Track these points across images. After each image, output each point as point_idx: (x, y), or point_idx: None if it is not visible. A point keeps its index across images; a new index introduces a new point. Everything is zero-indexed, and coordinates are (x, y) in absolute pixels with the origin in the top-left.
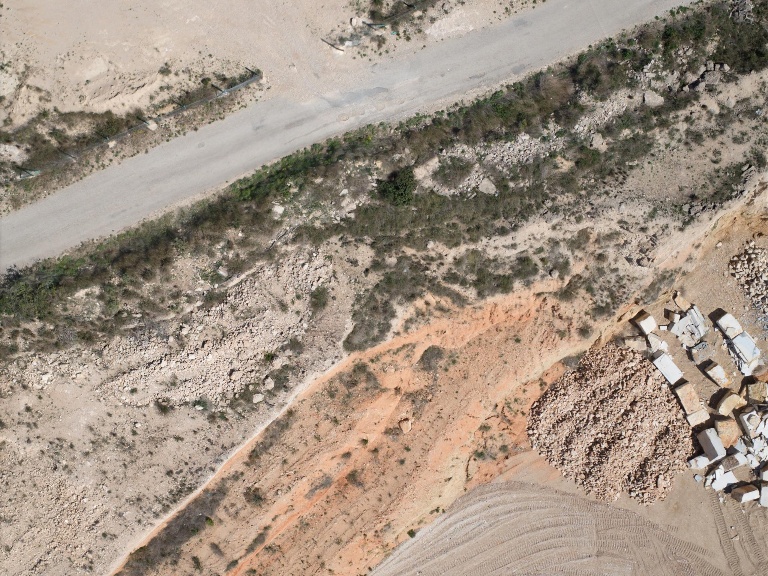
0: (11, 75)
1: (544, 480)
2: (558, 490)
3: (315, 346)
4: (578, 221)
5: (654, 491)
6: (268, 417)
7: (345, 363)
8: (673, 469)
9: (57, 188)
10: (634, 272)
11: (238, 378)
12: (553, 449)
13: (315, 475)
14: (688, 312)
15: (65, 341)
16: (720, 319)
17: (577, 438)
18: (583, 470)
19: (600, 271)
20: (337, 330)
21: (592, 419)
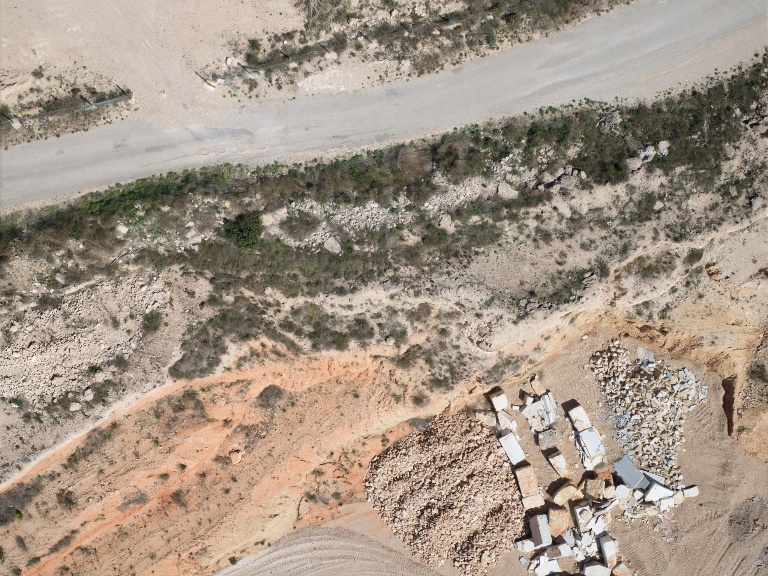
0: None
1: (374, 533)
2: (385, 545)
3: (140, 367)
4: (416, 295)
5: (477, 565)
6: (82, 427)
7: (174, 387)
8: (500, 547)
9: None
10: (476, 352)
11: (59, 384)
12: (386, 505)
13: (129, 490)
14: (542, 397)
15: None
16: (571, 410)
17: (410, 499)
18: (413, 531)
19: (442, 345)
20: (164, 356)
21: (428, 483)
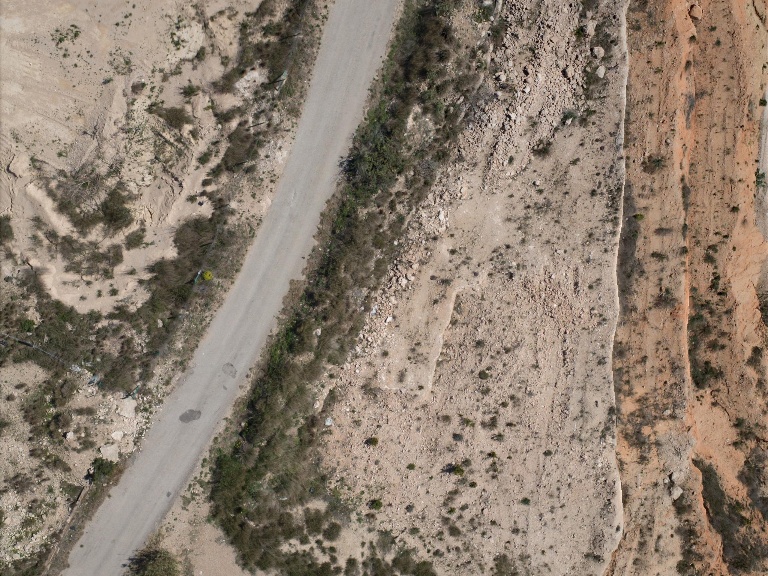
0: (190, 26)
1: None
2: None
3: None
4: None
5: None
6: (622, 78)
7: None
8: None
9: (310, 70)
10: None
11: (573, 72)
12: None
13: (681, 102)
14: None
15: (430, 174)
16: None
17: None
18: None
19: None
20: None
21: None
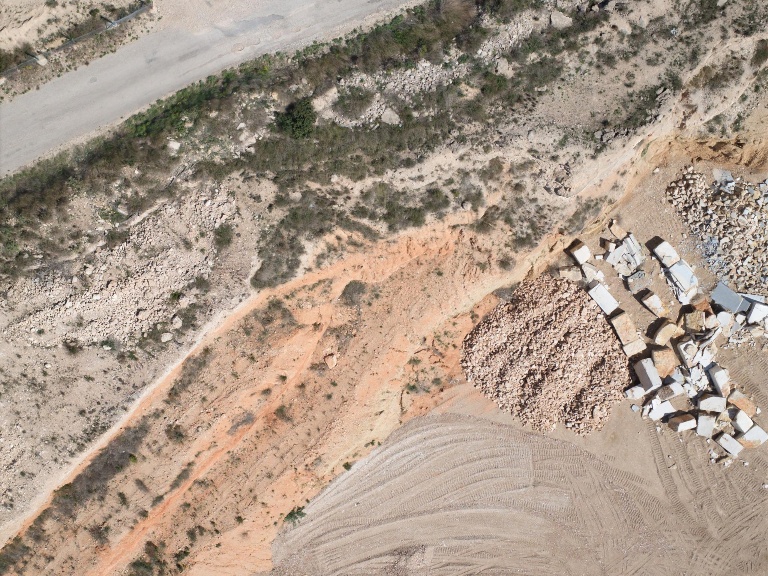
0: None
1: (480, 412)
2: (494, 422)
3: (222, 284)
4: (486, 151)
5: (590, 422)
6: (178, 356)
7: (258, 300)
8: (609, 399)
9: None
10: (555, 202)
11: (145, 317)
12: (488, 381)
13: (235, 412)
14: (624, 241)
15: None
16: (656, 247)
17: (510, 370)
18: (519, 402)
19: (518, 201)
20: (243, 267)
21: (525, 351)
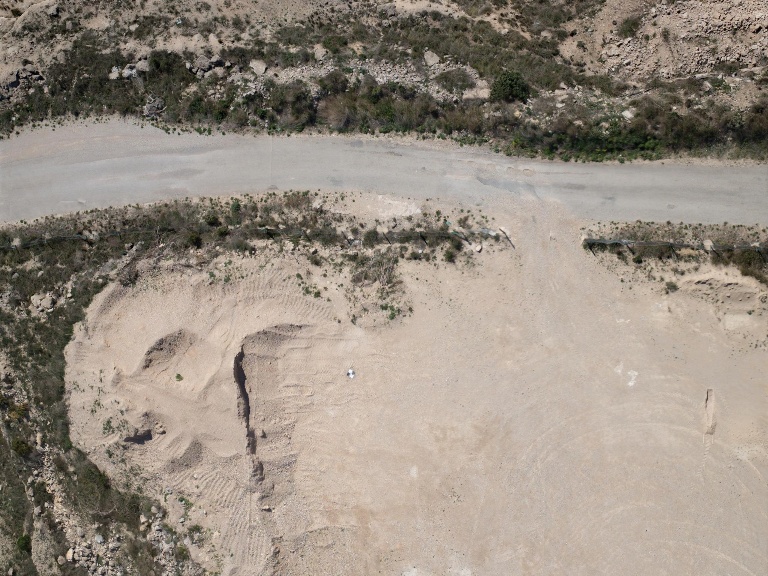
0: None
1: None
2: None
3: None
4: None
5: None
6: None
7: None
8: None
9: None
10: None
11: None
12: None
13: None
14: None
15: None
16: None
17: None
18: None
19: None
20: None
21: None
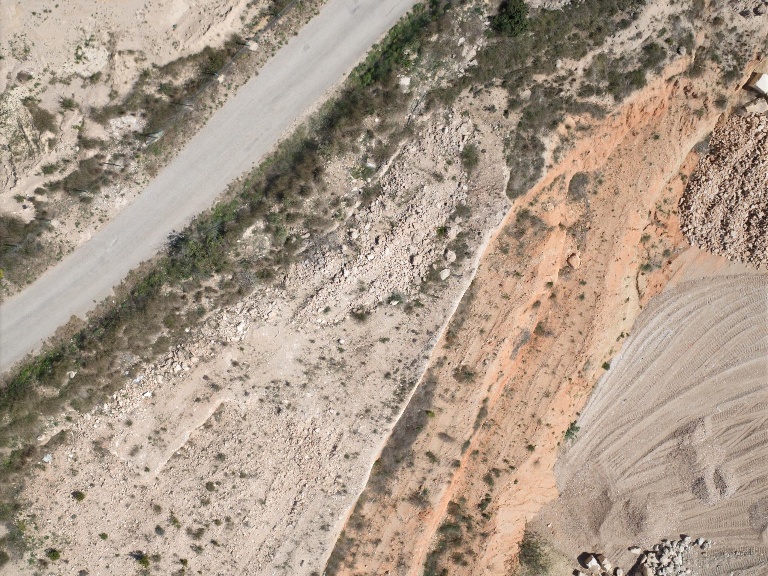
0: (98, 48)
1: (712, 271)
2: (728, 275)
3: (481, 204)
4: None
5: None
6: (461, 289)
7: (509, 214)
8: None
9: (185, 141)
10: (751, 25)
11: (420, 262)
12: (712, 238)
13: (514, 333)
14: None
15: (247, 286)
16: None
17: (733, 217)
18: (746, 247)
19: (719, 36)
20: (497, 181)
21: (741, 194)
